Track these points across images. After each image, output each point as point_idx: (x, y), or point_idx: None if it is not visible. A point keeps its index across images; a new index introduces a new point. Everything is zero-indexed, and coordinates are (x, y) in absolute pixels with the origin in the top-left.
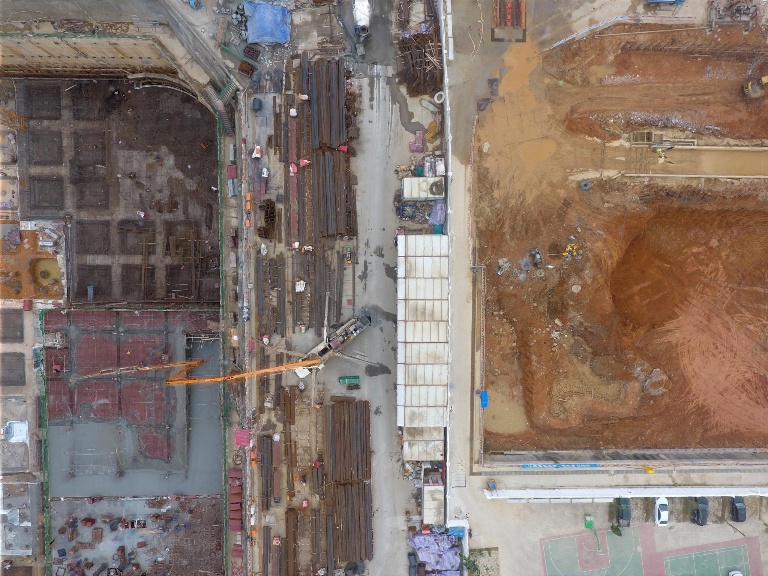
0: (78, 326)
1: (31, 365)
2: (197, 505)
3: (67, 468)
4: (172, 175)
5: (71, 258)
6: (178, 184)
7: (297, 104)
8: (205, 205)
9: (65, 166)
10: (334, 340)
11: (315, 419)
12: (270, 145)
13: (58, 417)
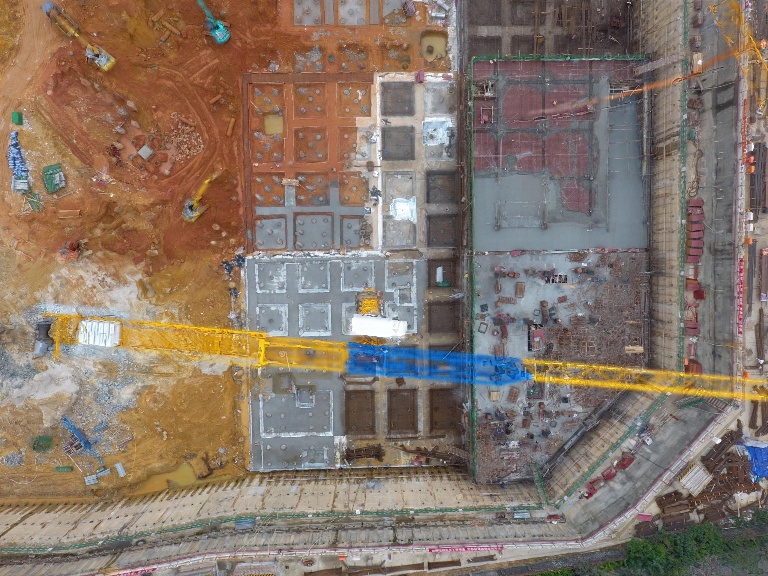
0: (505, 76)
1: (421, 139)
2: (617, 259)
3: (491, 221)
4: None
5: (463, 29)
6: None
7: None
8: None
9: None
10: None
11: None
12: None
13: (483, 170)
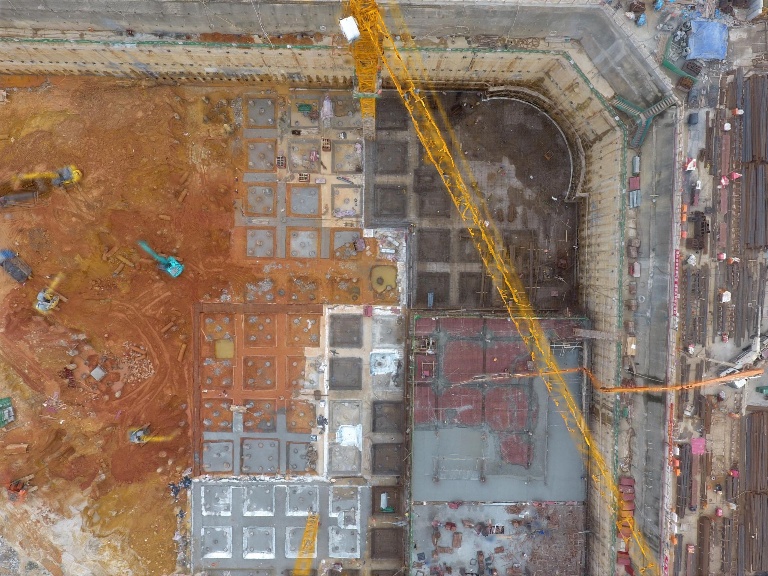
0: (447, 333)
1: (368, 370)
2: (555, 511)
3: (430, 472)
4: (512, 185)
5: (412, 265)
6: (518, 194)
7: (728, 118)
8: (544, 215)
9: (410, 175)
10: (765, 350)
11: (730, 428)
12: (702, 158)
13: (423, 422)
